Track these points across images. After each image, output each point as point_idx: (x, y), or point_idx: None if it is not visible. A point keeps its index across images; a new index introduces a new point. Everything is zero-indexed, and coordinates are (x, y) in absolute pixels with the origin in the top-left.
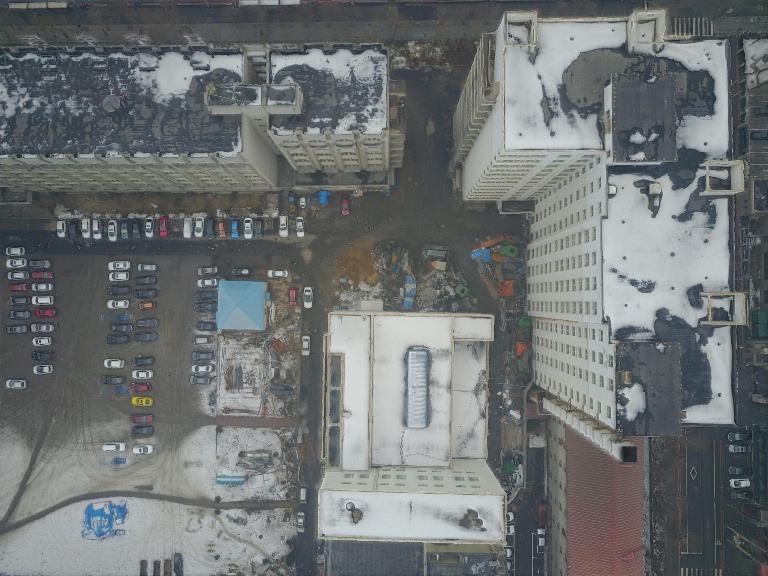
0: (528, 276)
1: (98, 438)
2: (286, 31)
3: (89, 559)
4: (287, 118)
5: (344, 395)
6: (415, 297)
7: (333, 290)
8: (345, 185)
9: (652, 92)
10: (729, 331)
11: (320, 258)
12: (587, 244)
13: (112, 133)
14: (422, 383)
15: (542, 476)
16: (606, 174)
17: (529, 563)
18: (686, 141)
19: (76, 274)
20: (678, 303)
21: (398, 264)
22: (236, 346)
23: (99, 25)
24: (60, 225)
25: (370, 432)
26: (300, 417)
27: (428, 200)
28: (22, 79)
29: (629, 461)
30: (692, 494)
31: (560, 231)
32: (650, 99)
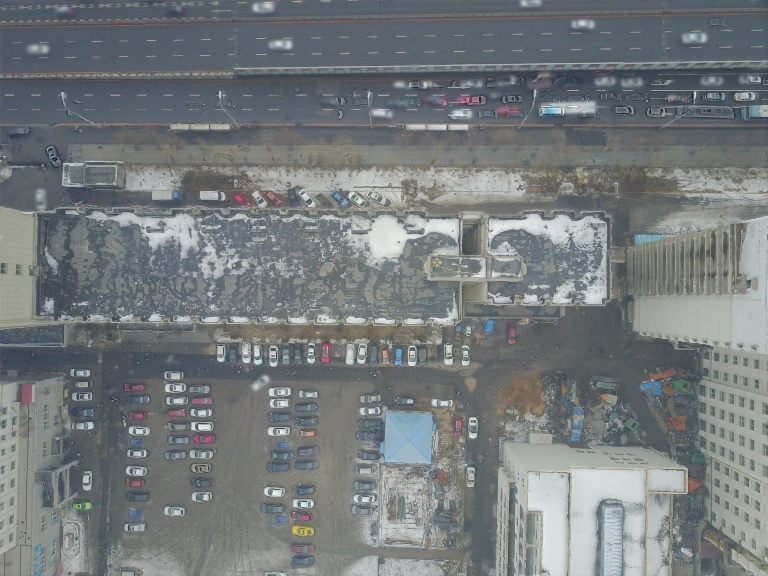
0: (701, 412)
1: (257, 567)
2: (451, 154)
3: None
4: (504, 284)
5: (542, 554)
6: (583, 429)
7: (498, 420)
8: (516, 317)
9: None
10: None
11: (485, 387)
12: None
13: (323, 296)
14: (618, 540)
15: None
16: None
17: None
18: None
19: (235, 399)
20: None
21: (567, 396)
22: (399, 475)
23: (259, 145)
24: (221, 350)
25: None
26: (464, 549)
27: (595, 329)
28: (231, 240)
29: None
30: None
31: None
32: None
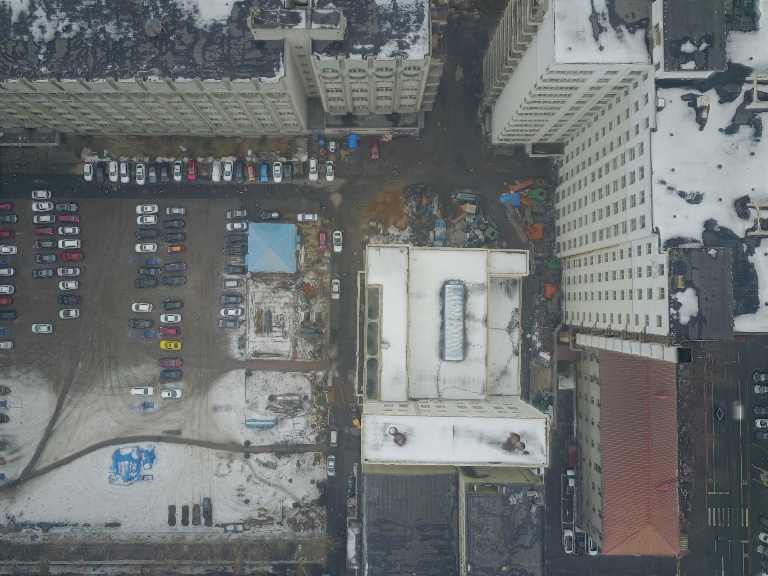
0: (557, 219)
1: (125, 383)
2: None
3: (116, 505)
4: (329, 44)
5: (382, 326)
6: (445, 240)
7: (363, 234)
8: (376, 128)
9: (702, 2)
10: None
11: (349, 202)
12: (633, 161)
13: (153, 58)
14: (459, 316)
15: (571, 418)
16: (655, 87)
17: (559, 504)
18: (732, 56)
19: (103, 218)
20: (726, 214)
21: (428, 207)
22: (265, 290)
23: None
24: (87, 168)
25: (408, 363)
26: (330, 360)
27: (457, 145)
28: (61, 4)
29: None
30: (719, 434)
31: (597, 162)
32: (700, 9)
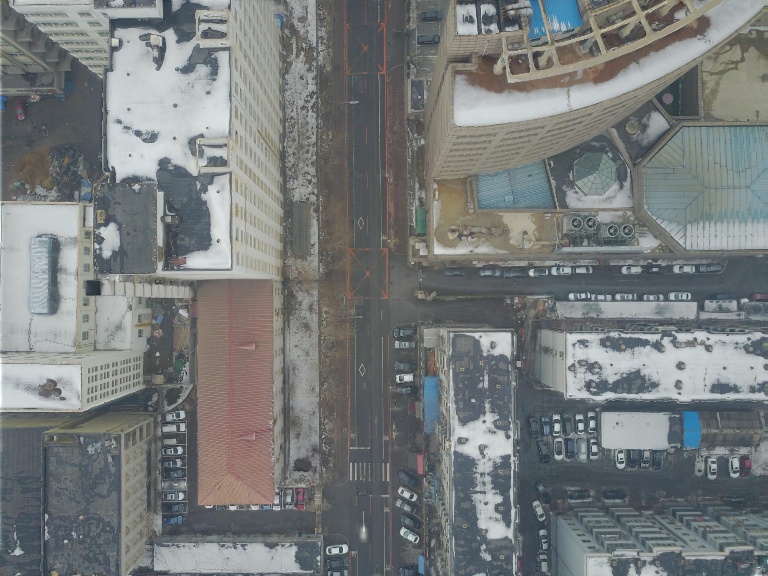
0: None
1: None
2: None
3: None
4: None
5: None
6: (90, 200)
7: (10, 195)
8: (13, 88)
9: None
10: (228, 179)
11: None
12: None
13: None
14: (44, 269)
15: None
16: (109, 27)
17: None
18: None
19: None
20: (179, 152)
21: (71, 167)
22: None
23: None
24: None
25: None
26: None
27: None
28: None
29: (92, 294)
30: (361, 390)
31: None
32: None
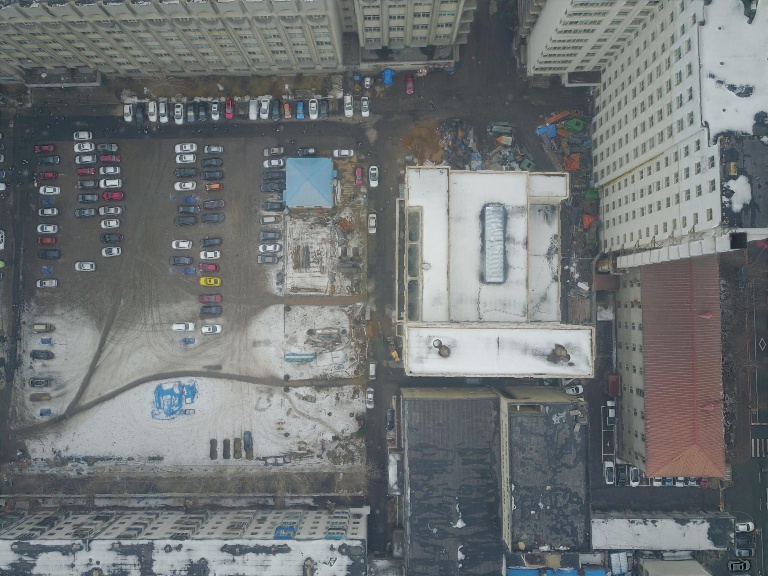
0: (594, 149)
1: (167, 319)
2: None
3: (159, 439)
4: None
5: (423, 247)
6: None
7: (398, 169)
8: (411, 61)
9: None
10: None
11: (385, 138)
12: (678, 62)
13: None
14: (499, 237)
15: (610, 349)
16: None
17: (599, 436)
18: None
19: (143, 158)
20: None
21: (464, 140)
22: (303, 226)
23: None
24: (127, 109)
25: None
26: (367, 295)
27: (492, 78)
28: None
29: (738, 247)
30: (761, 365)
31: None
32: None
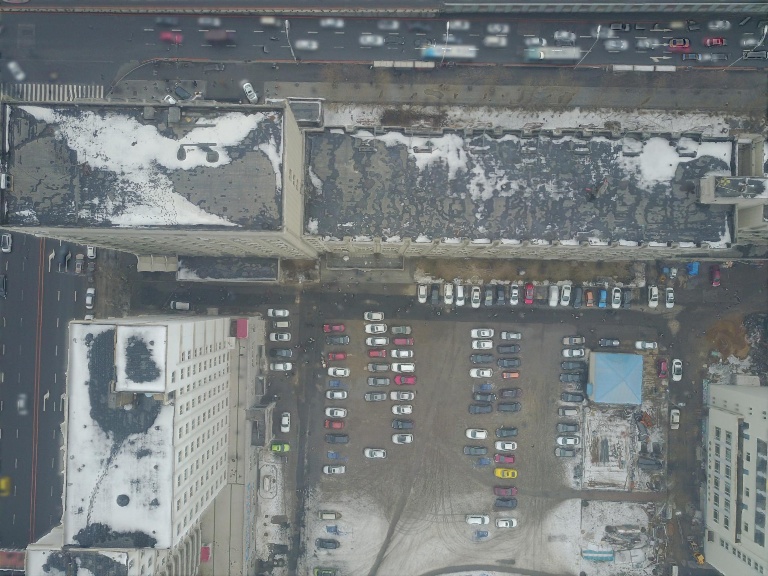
0: None
1: (458, 510)
2: (654, 97)
3: None
4: None
5: None
6: None
7: (701, 363)
8: (726, 258)
9: None
10: None
11: (688, 330)
12: None
13: (593, 219)
14: None
15: None
16: None
17: None
18: None
19: (436, 341)
20: None
21: None
22: (601, 418)
23: (460, 85)
24: (423, 291)
25: None
26: (667, 492)
27: None
28: (500, 161)
29: None
30: None
31: None
32: None
